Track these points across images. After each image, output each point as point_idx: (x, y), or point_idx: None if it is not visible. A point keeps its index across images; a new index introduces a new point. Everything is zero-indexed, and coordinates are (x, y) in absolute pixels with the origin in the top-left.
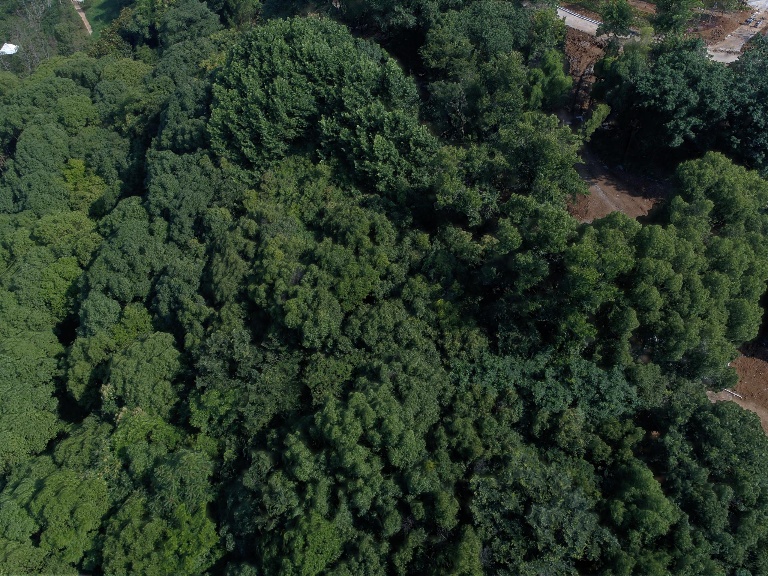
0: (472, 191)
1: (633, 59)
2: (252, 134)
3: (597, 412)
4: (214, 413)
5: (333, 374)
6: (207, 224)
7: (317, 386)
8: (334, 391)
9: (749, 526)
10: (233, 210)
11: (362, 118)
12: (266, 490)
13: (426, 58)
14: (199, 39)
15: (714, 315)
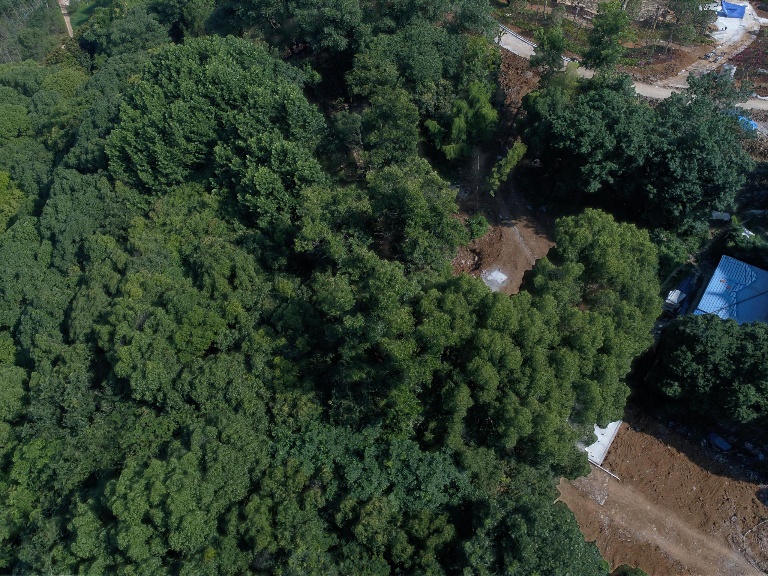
0: (334, 237)
1: (554, 96)
2: (149, 158)
3: (412, 502)
4: (33, 465)
5: (151, 434)
6: (87, 252)
7: (133, 446)
8: (150, 453)
9: None
10: (121, 237)
11: (252, 148)
12: (37, 567)
13: (350, 83)
14: (138, 52)
15: (555, 398)
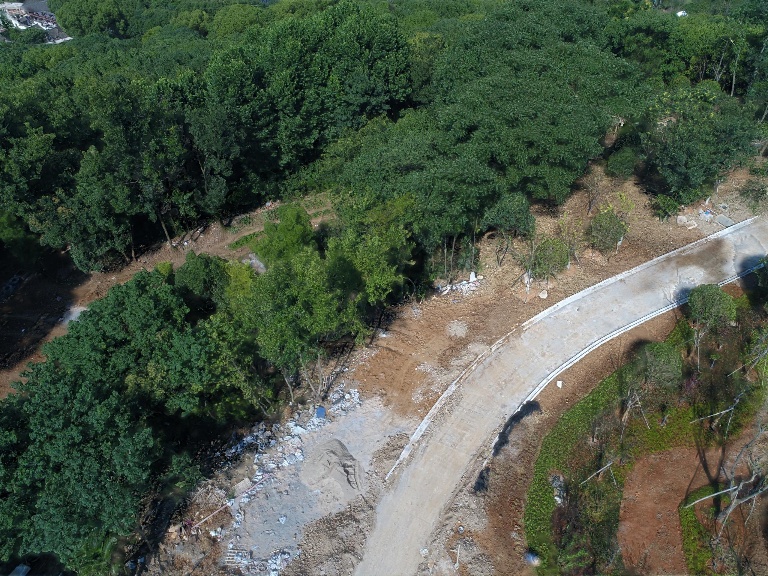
0: None
1: None
2: None
3: None
4: None
5: None
6: None
7: None
8: None
9: None
10: None
11: None
12: None
13: None
14: None
15: None
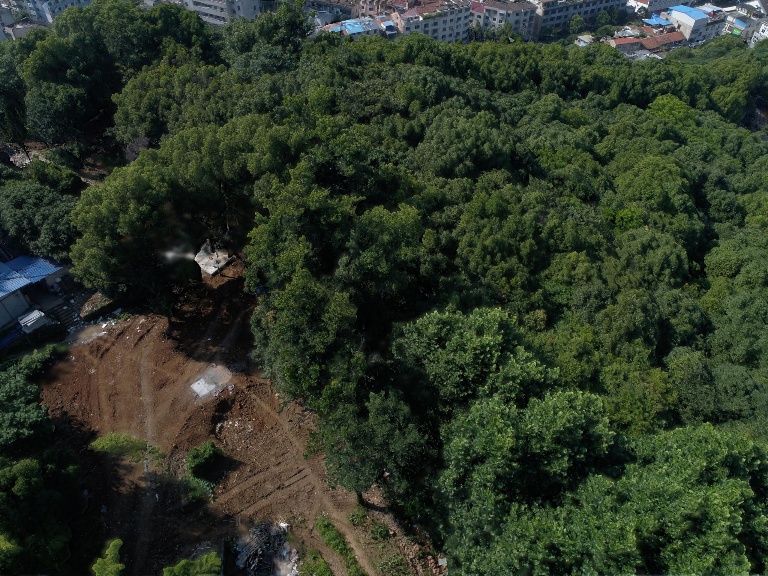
0: (382, 214)
1: None
2: None
3: None
4: None
5: None
6: None
7: None
8: None
9: (279, 76)
10: None
11: None
12: None
13: None
14: None
15: None
